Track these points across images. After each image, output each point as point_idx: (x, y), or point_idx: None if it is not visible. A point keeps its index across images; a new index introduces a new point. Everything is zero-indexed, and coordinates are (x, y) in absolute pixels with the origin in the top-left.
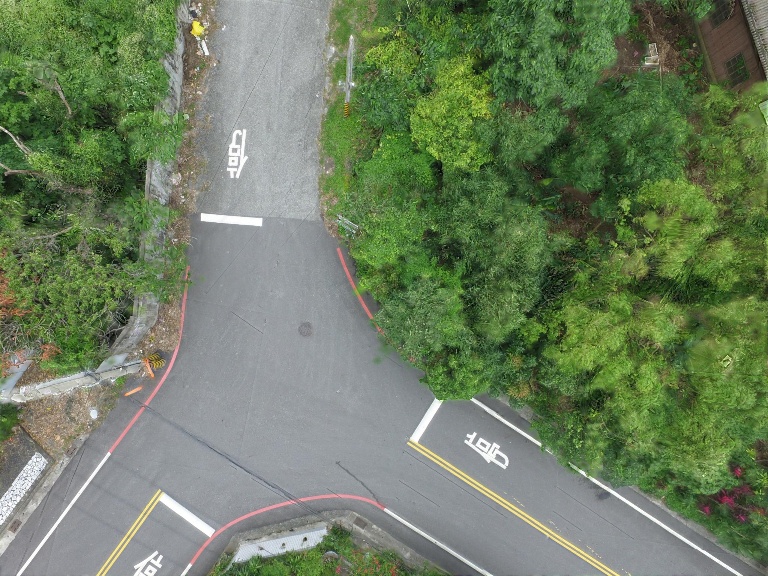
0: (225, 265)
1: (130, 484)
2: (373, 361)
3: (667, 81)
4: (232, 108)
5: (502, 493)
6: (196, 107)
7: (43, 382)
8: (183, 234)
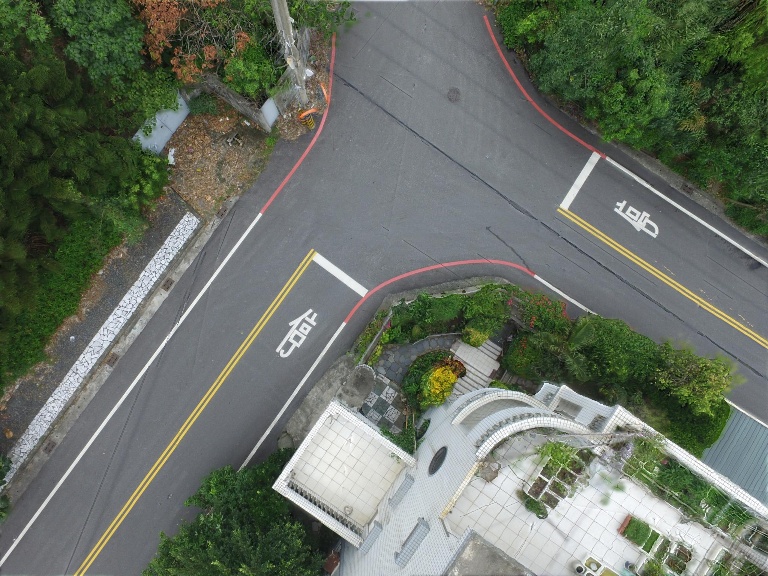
0: (372, 30)
1: (282, 243)
2: (522, 128)
3: None
4: None
5: (652, 261)
6: None
7: (192, 144)
8: (328, 1)
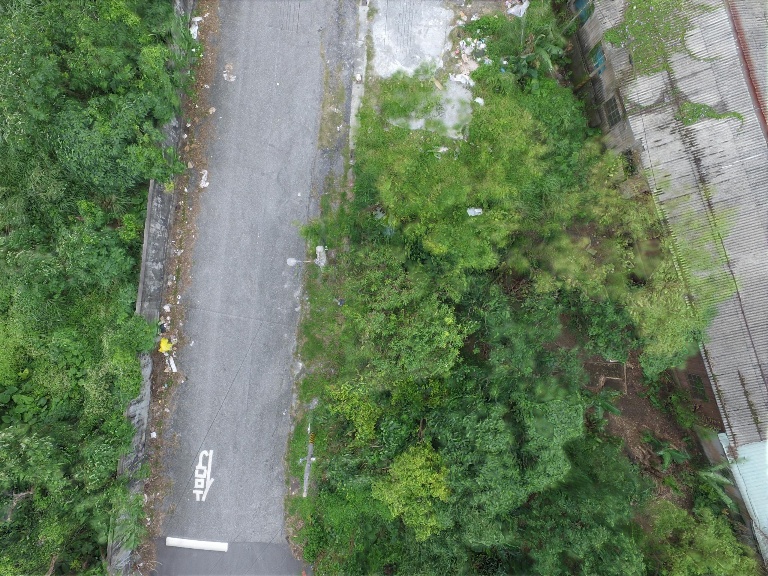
0: None
1: None
2: None
3: (631, 377)
4: (199, 428)
5: None
6: (163, 425)
7: None
8: (148, 559)
